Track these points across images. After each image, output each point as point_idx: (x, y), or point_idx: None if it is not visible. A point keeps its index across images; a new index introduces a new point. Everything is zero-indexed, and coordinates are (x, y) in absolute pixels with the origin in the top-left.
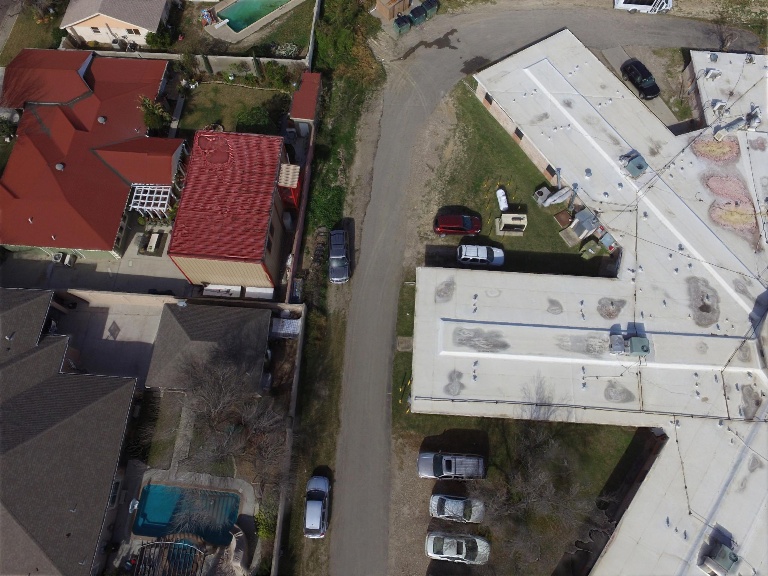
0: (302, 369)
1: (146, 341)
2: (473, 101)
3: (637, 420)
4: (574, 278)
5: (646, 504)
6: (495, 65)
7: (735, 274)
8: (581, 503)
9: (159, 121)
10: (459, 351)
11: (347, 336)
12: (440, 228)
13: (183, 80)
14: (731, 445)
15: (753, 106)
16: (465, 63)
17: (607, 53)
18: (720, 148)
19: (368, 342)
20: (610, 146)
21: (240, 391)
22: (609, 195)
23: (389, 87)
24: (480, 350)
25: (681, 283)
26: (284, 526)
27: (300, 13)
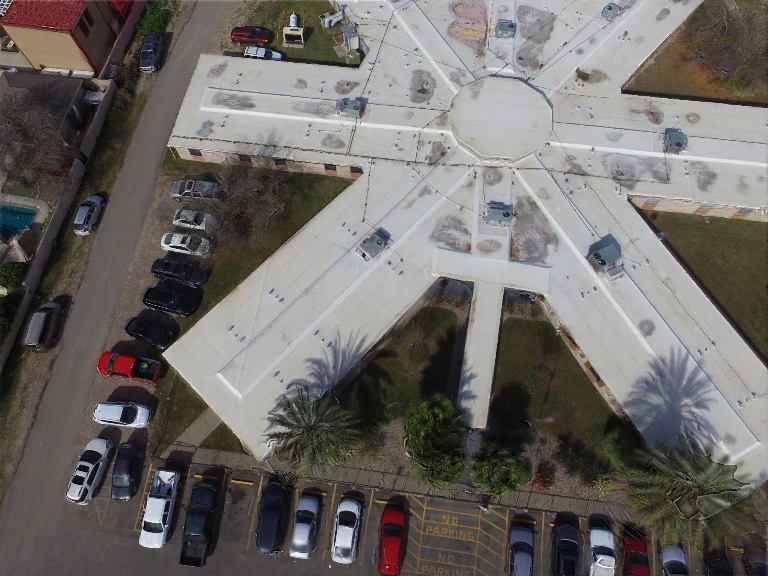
0: (104, 128)
1: None
2: None
3: (342, 160)
4: (323, 67)
5: (331, 213)
6: None
7: (453, 69)
8: (252, 181)
9: None
10: (215, 107)
11: (145, 109)
12: (233, 35)
13: None
14: (411, 180)
15: None
16: None
17: None
18: None
19: (160, 113)
20: None
21: (27, 108)
22: (370, 13)
23: None
24: (231, 108)
25: (408, 73)
26: (62, 227)
27: None
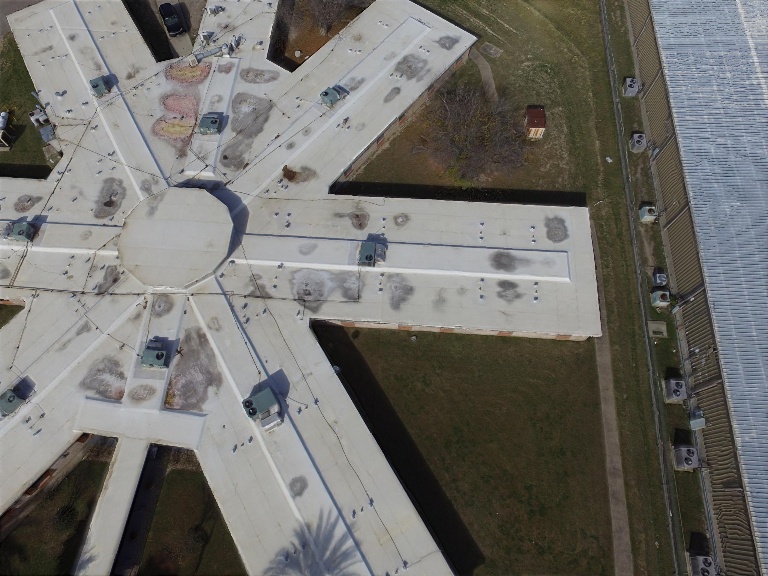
0: None
1: None
2: None
3: (3, 293)
4: (7, 179)
5: None
6: (28, 7)
7: (147, 175)
8: None
9: None
10: None
11: None
12: None
13: None
14: (74, 314)
15: (241, 37)
16: None
17: None
18: (192, 72)
19: None
20: (91, 71)
21: None
22: (72, 112)
23: None
24: None
25: (98, 183)
26: None
27: None
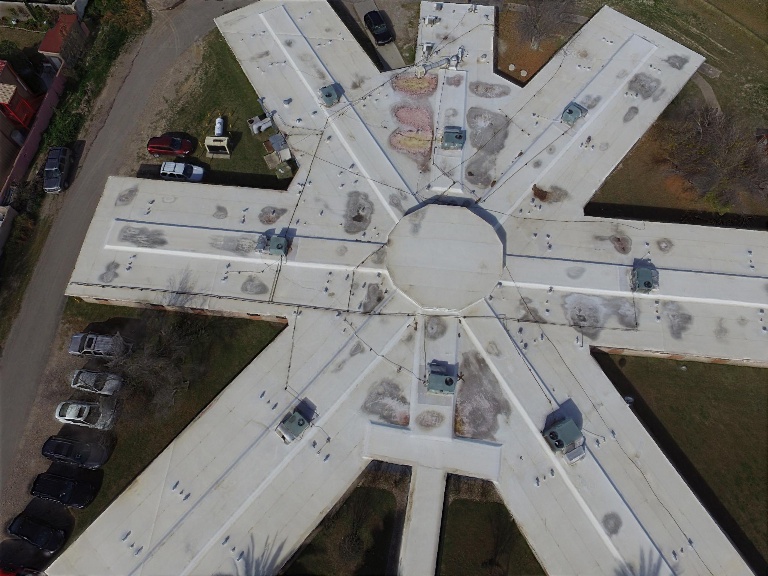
0: (0, 263)
1: None
2: (221, 44)
3: (264, 309)
4: (246, 189)
5: (249, 379)
6: (235, 10)
7: (394, 190)
8: (148, 360)
9: None
10: (121, 245)
11: (49, 238)
12: (149, 147)
13: None
14: (342, 333)
15: (463, 49)
16: None
17: (358, 6)
18: (419, 84)
19: (65, 243)
20: (315, 79)
21: None
22: (302, 121)
23: (151, 32)
24: (140, 245)
25: (342, 196)
26: None
27: None
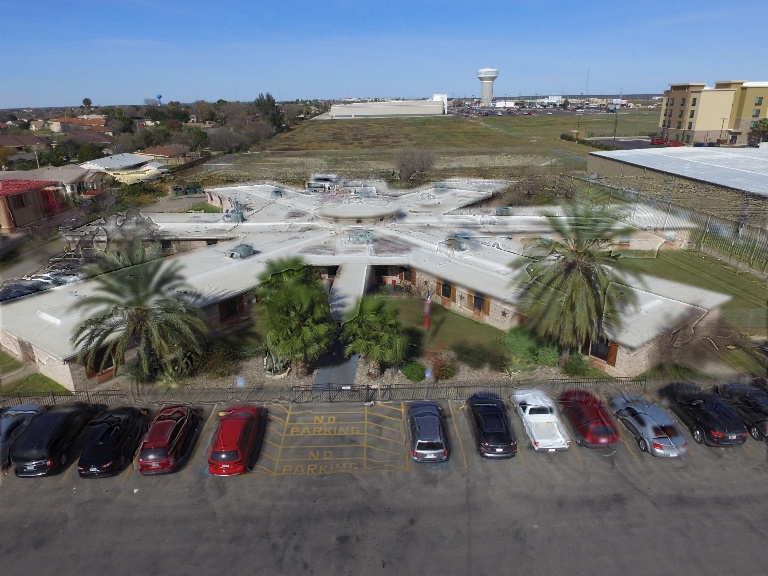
0: (5, 249)
1: None
2: None
3: None
4: None
5: None
6: None
7: None
8: (133, 210)
9: None
10: (117, 223)
11: (52, 242)
12: None
13: None
14: None
15: None
16: None
17: None
18: None
19: (65, 242)
20: (267, 195)
21: None
22: (257, 202)
23: None
24: None
25: None
26: None
27: None
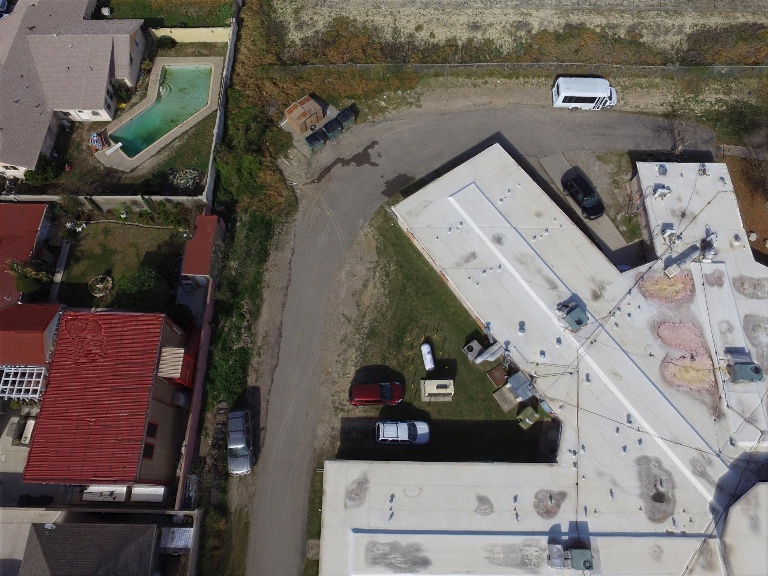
0: None
1: (19, 558)
2: (395, 231)
3: None
4: (506, 466)
5: None
6: (416, 194)
7: (692, 451)
8: None
9: (33, 284)
10: (372, 574)
11: (250, 542)
12: (355, 402)
13: (67, 224)
14: None
15: (708, 229)
16: (387, 183)
17: (546, 162)
18: (672, 285)
19: (274, 549)
20: (546, 291)
21: None
22: (546, 354)
23: (301, 218)
24: (396, 571)
25: (630, 465)
26: None
27: (202, 130)
